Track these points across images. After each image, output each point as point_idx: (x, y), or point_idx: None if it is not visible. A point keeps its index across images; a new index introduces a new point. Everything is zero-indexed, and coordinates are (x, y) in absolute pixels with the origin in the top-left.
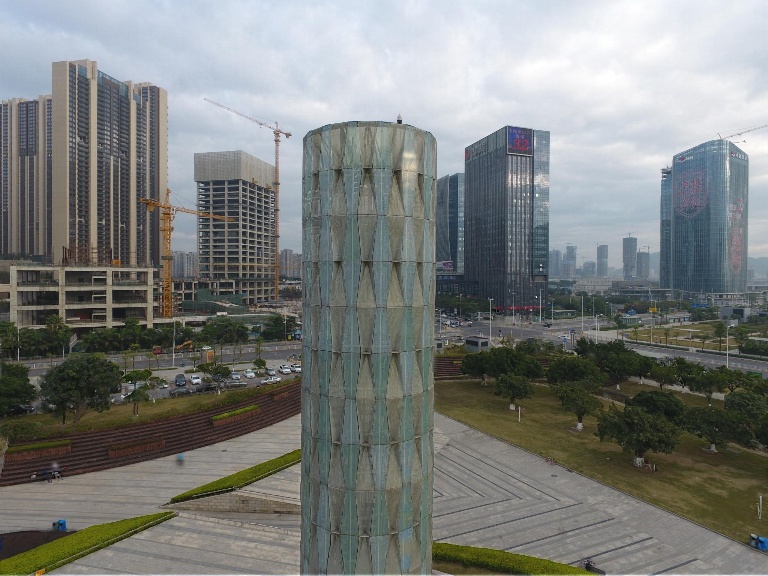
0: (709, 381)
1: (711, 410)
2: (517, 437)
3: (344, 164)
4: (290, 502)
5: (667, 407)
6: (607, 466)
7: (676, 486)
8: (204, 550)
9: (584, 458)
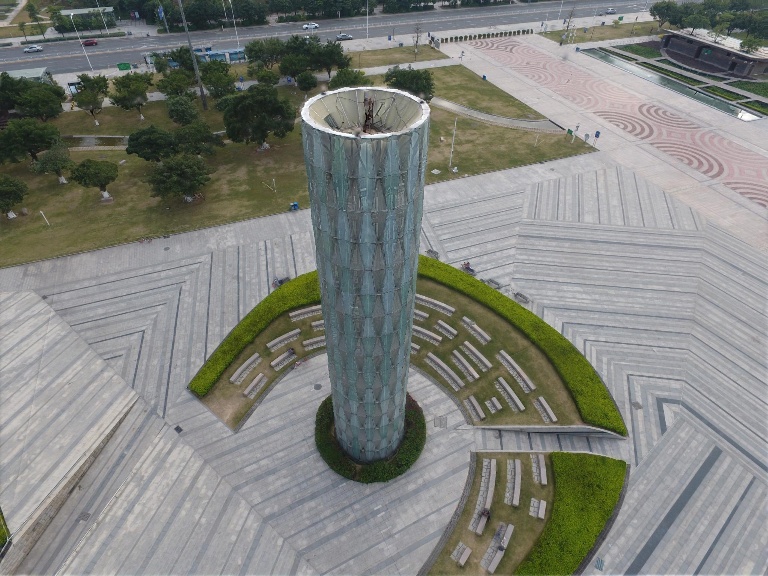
0: (136, 95)
1: (192, 129)
2: (81, 241)
3: (422, 157)
4: (76, 470)
5: (165, 142)
6: (178, 215)
7: (226, 200)
8: (125, 561)
9: (156, 220)
